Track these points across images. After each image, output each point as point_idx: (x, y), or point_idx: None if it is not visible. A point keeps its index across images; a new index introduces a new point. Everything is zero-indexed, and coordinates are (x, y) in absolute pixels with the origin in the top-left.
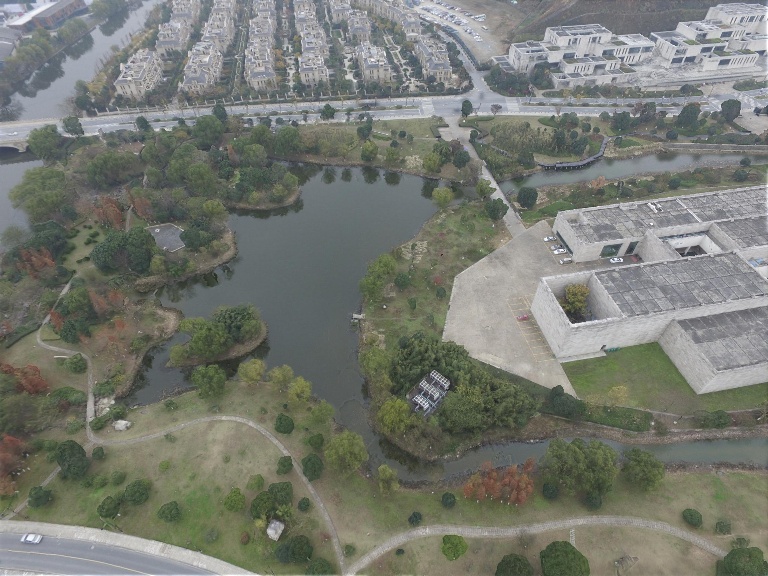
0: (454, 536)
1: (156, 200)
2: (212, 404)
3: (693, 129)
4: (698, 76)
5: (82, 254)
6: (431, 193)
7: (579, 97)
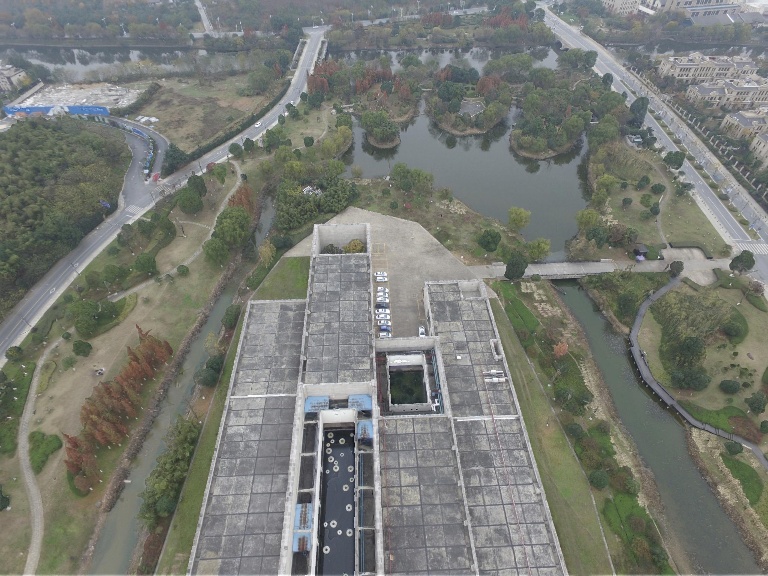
0: None
1: (494, 91)
2: (335, 130)
3: None
4: None
5: None
6: None
7: None
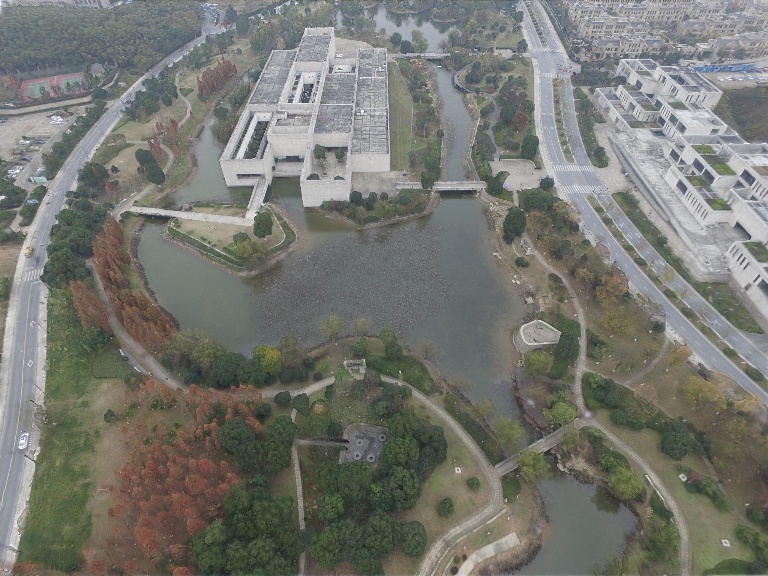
0: None
1: None
2: None
3: None
4: (641, 169)
5: None
6: None
7: None
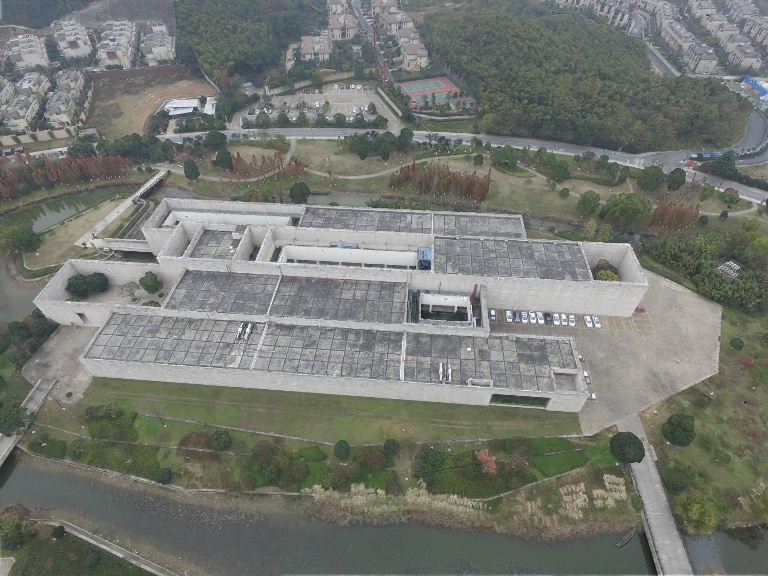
0: None
1: None
2: None
3: None
4: None
5: None
6: None
7: None
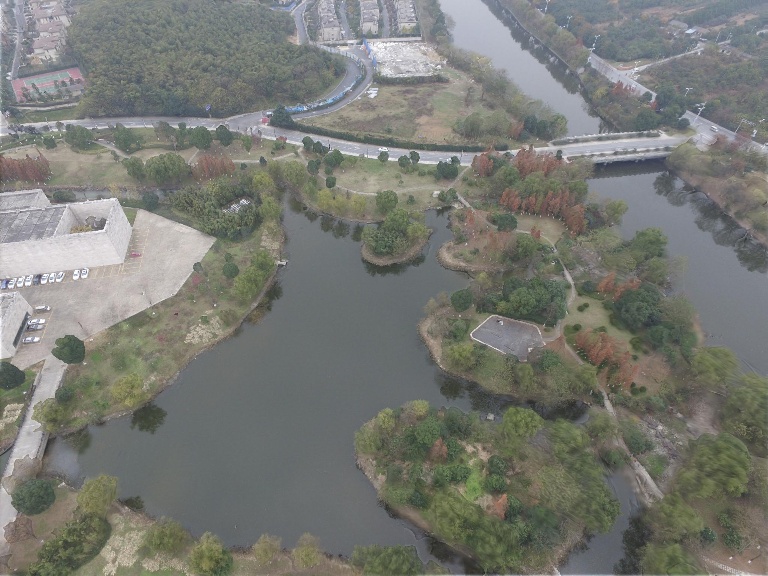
0: (245, 139)
1: (544, 352)
2: None
3: None
4: None
5: (594, 315)
6: None
7: None
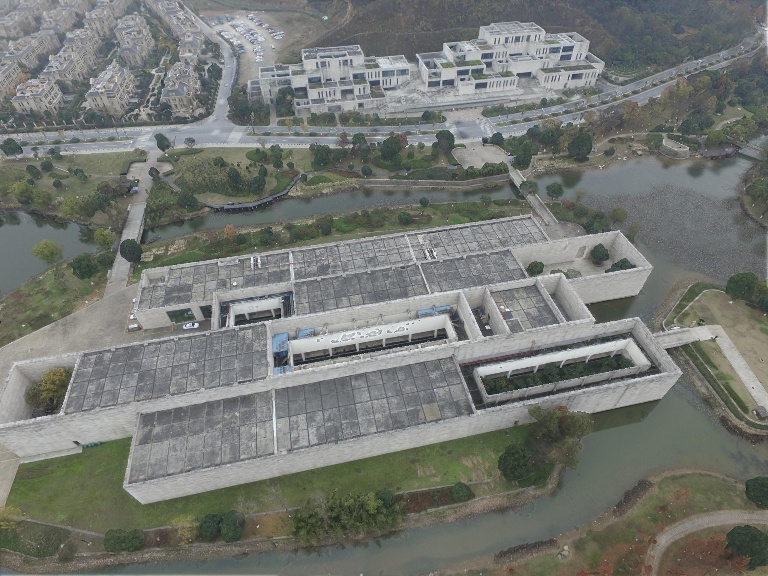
0: None
1: None
2: None
3: (396, 163)
4: (450, 101)
5: None
6: (92, 238)
7: (303, 126)
